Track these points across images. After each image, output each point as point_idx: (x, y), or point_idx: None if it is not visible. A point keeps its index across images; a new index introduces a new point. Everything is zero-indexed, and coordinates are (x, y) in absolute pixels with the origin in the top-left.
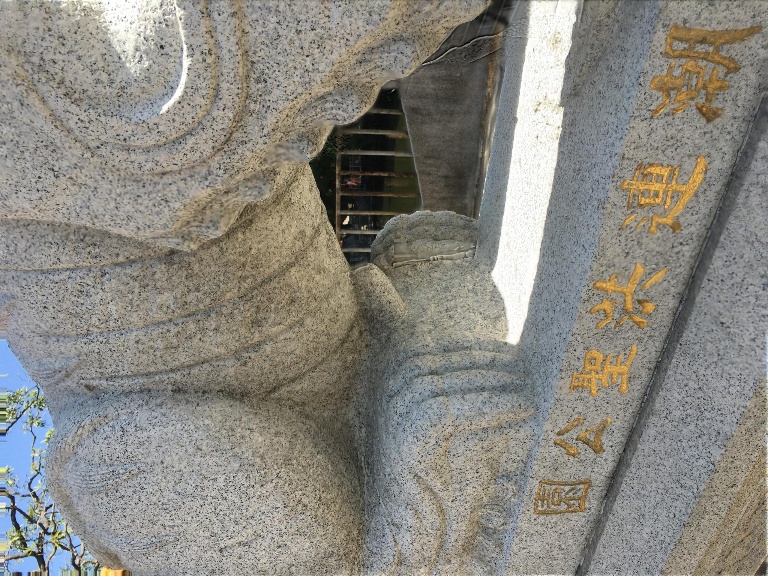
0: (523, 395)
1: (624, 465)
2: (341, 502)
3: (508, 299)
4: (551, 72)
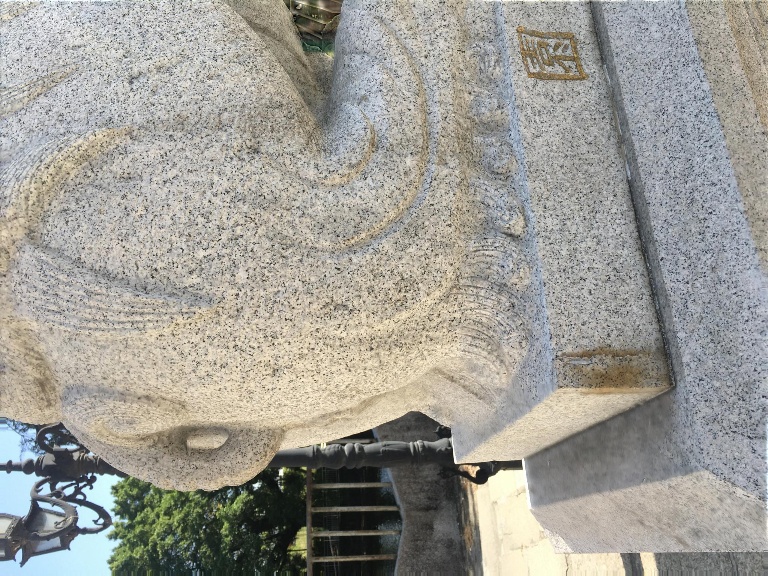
0: None
1: (597, 6)
2: None
3: None
4: None
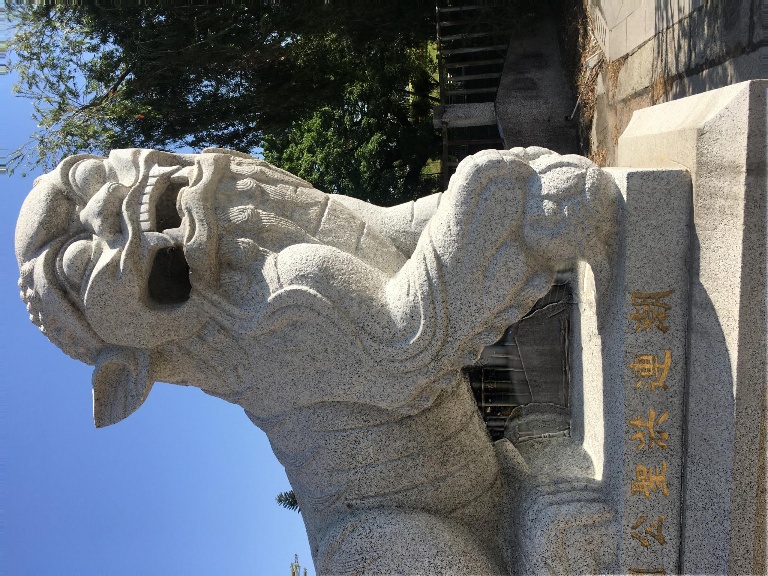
0: (606, 504)
1: (682, 554)
2: None
3: (593, 455)
4: (592, 319)
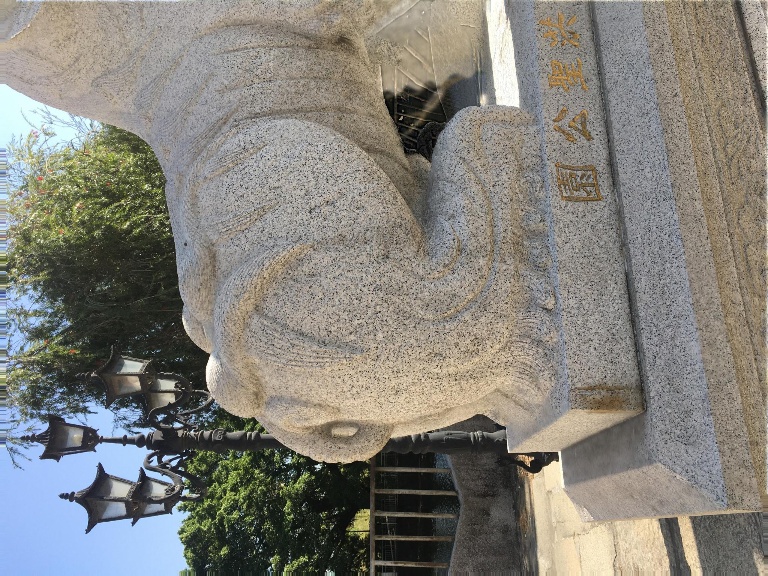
0: None
1: (612, 146)
2: (406, 204)
3: None
4: None
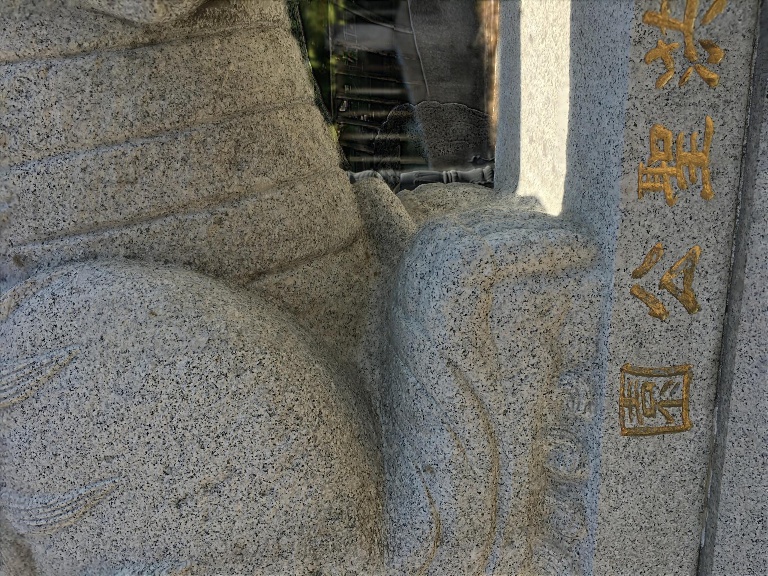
0: (578, 233)
1: (731, 329)
2: (350, 436)
3: (540, 186)
4: None
